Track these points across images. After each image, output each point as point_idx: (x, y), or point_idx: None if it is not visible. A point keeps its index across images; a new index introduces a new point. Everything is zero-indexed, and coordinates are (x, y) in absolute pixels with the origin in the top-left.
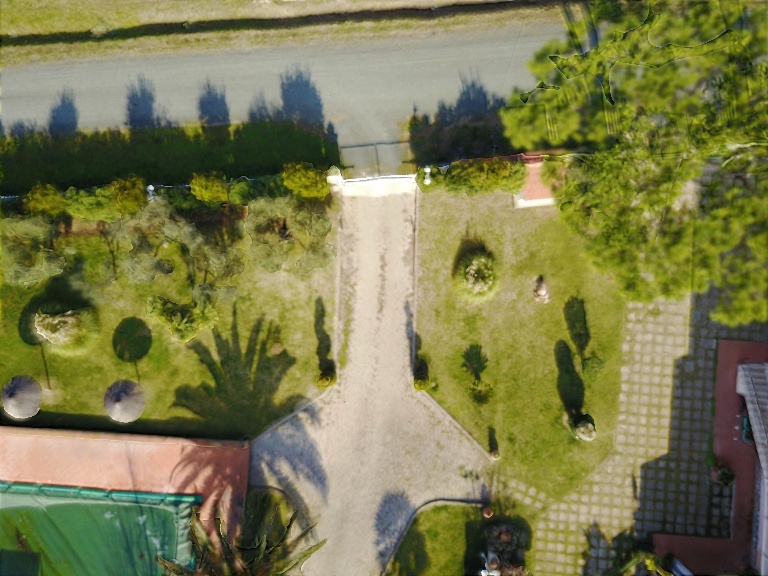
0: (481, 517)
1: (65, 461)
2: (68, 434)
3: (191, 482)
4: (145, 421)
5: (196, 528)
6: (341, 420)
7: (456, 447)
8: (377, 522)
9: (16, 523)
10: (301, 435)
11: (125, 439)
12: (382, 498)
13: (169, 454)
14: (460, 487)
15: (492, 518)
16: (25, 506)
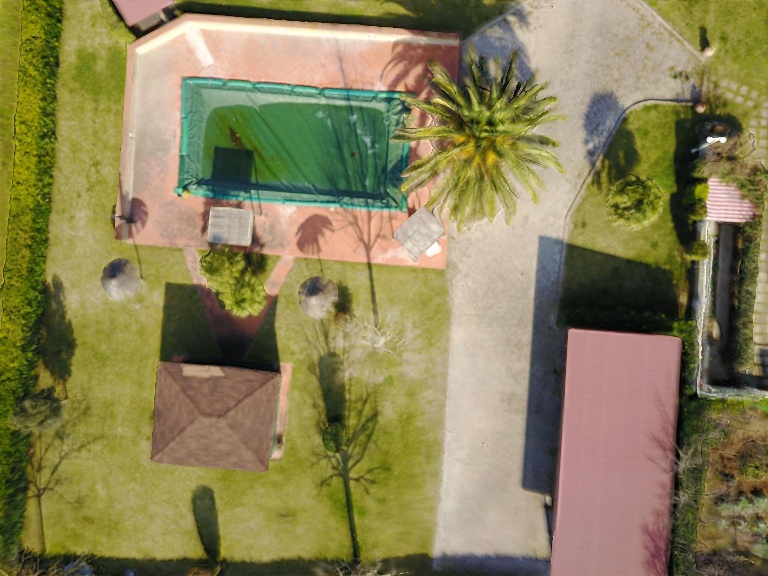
0: (691, 115)
1: (277, 60)
2: (285, 24)
3: (402, 80)
4: (358, 17)
5: (435, 70)
6: (549, 24)
7: (665, 49)
8: (585, 123)
9: (229, 123)
10: (509, 39)
11: (341, 29)
12: (590, 99)
13: (380, 53)
14: (669, 88)
15: (702, 116)
16: (238, 105)
